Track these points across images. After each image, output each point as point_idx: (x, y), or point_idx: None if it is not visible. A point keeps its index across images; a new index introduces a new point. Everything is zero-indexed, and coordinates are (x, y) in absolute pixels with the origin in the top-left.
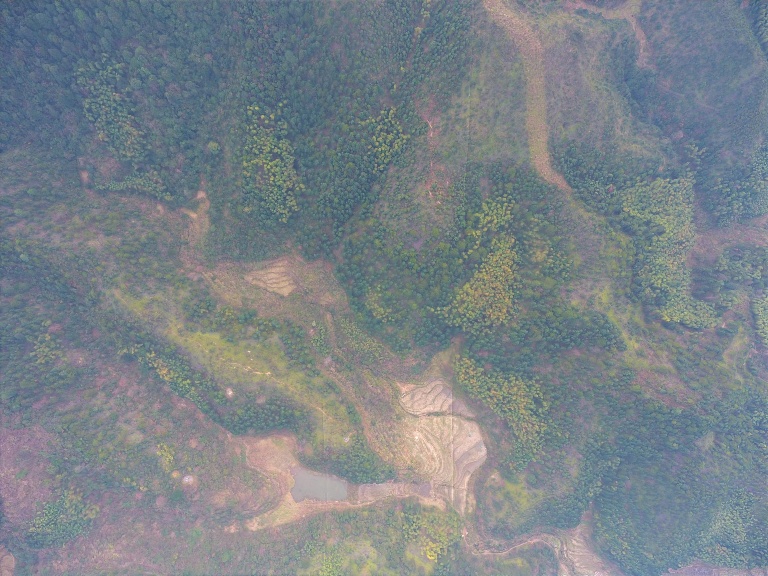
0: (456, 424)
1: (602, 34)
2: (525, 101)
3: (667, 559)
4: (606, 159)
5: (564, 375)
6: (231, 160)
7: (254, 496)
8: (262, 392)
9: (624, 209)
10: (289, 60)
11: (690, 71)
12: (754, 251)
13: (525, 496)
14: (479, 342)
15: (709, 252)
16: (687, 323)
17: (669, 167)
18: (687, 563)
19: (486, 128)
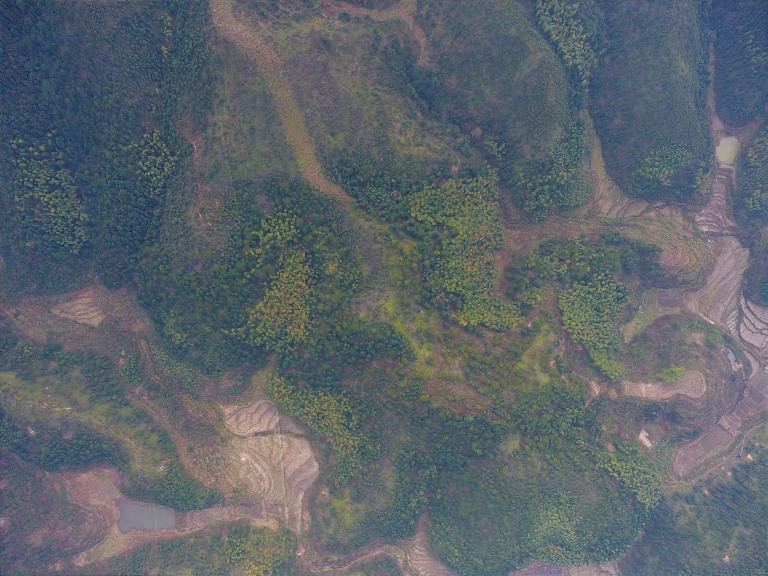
0: (285, 442)
1: (361, 38)
2: (278, 115)
3: (498, 563)
4: (386, 165)
5: (367, 388)
6: (6, 195)
7: (74, 532)
8: (65, 428)
9: (411, 214)
10: (47, 89)
11: (471, 67)
12: (565, 245)
13: (349, 511)
14: (285, 360)
15: (525, 248)
16: (487, 325)
17: (465, 166)
18: (525, 564)
19: (244, 145)
